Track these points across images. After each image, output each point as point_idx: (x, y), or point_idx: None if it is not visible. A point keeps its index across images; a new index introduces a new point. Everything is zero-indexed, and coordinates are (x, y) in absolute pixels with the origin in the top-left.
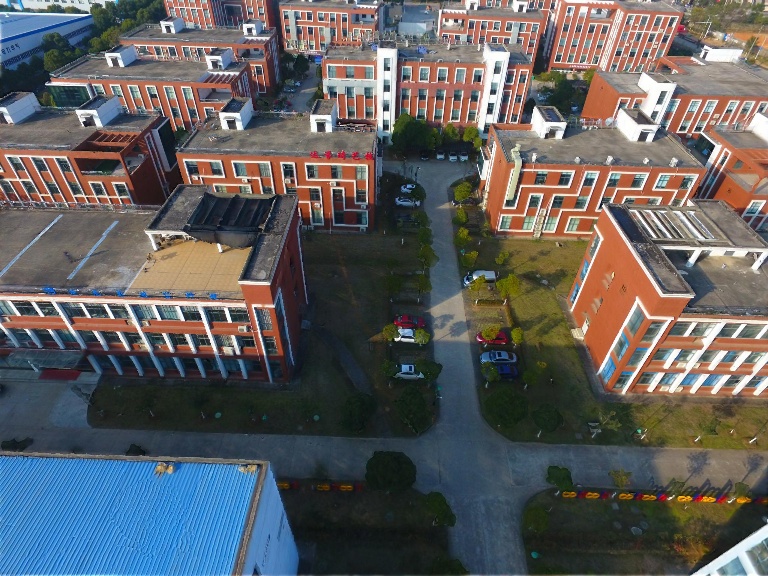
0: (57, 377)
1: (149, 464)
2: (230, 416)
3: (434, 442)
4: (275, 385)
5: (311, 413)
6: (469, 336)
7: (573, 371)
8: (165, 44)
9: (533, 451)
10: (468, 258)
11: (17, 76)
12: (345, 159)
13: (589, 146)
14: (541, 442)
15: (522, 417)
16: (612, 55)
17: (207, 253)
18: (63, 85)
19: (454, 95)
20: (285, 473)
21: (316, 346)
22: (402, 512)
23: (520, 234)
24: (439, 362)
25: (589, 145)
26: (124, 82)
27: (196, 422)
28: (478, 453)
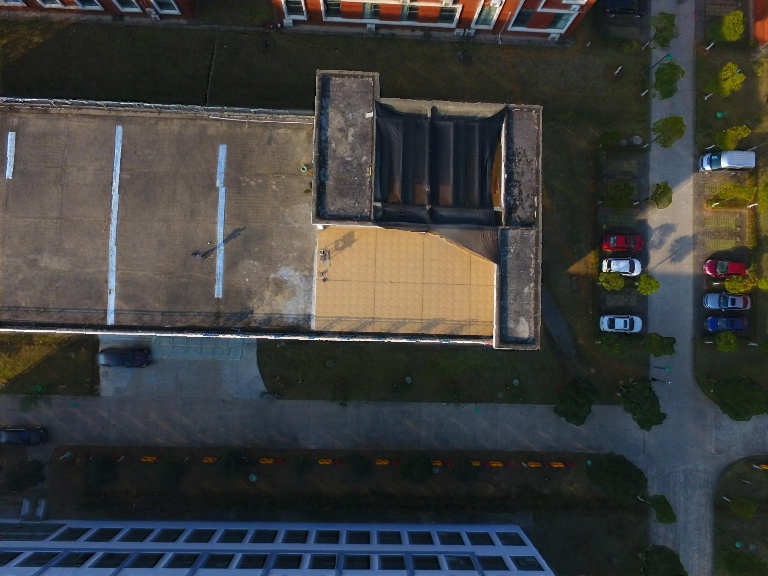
0: None
1: None
2: (422, 382)
3: None
4: None
5: (510, 377)
6: (694, 261)
7: None
8: None
9: None
10: (731, 138)
11: None
12: None
13: None
14: None
15: None
16: None
17: (401, 234)
18: None
19: None
20: (492, 446)
21: None
22: None
23: None
24: (653, 303)
25: None
26: None
27: (387, 390)
28: (684, 421)
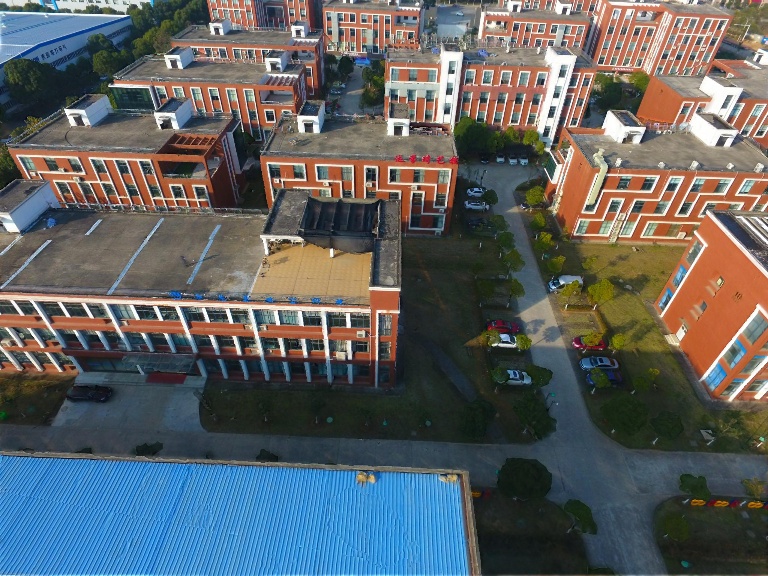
0: (164, 380)
1: (348, 473)
2: (342, 421)
3: (550, 448)
4: (380, 390)
5: None
6: (564, 341)
7: (675, 377)
8: (216, 46)
9: (651, 458)
10: (555, 263)
11: (67, 77)
12: (429, 163)
13: (668, 151)
14: (657, 449)
15: (643, 424)
16: (658, 58)
17: (318, 258)
18: (126, 87)
19: (516, 98)
20: None
21: (413, 351)
22: (533, 519)
23: (595, 238)
24: None
25: (668, 150)
26: (187, 84)
27: (309, 427)
28: (596, 460)
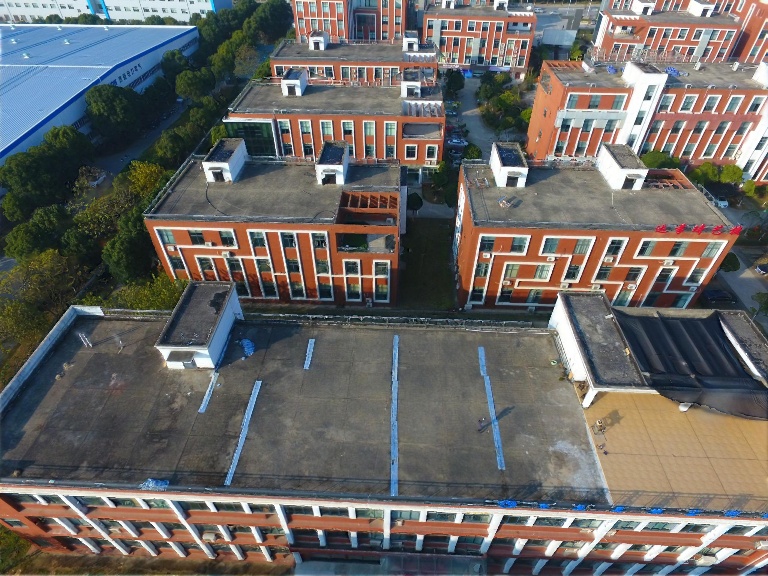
0: None
1: None
2: None
3: None
4: None
5: None
6: None
7: None
8: (322, 64)
9: None
10: None
11: (148, 102)
12: (700, 234)
13: None
14: None
15: None
16: None
17: (663, 412)
18: (243, 121)
19: (717, 127)
20: None
21: None
22: None
23: None
24: None
25: None
26: (316, 117)
27: None
28: None
